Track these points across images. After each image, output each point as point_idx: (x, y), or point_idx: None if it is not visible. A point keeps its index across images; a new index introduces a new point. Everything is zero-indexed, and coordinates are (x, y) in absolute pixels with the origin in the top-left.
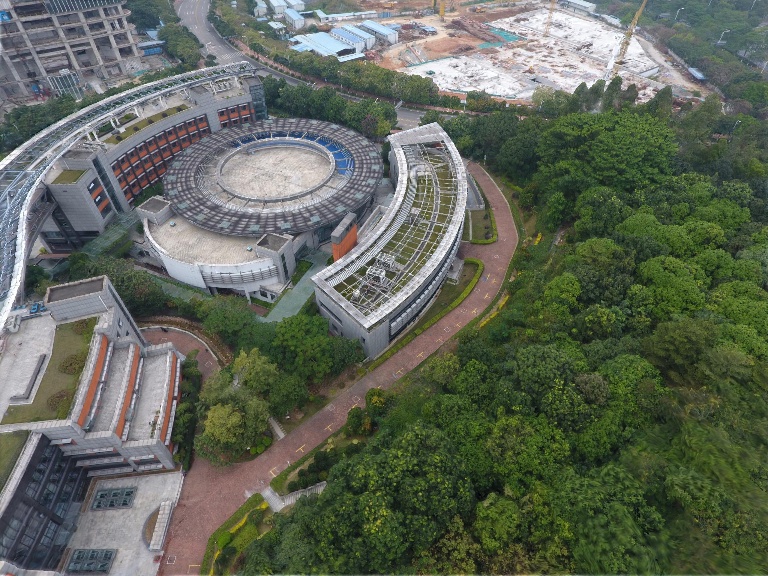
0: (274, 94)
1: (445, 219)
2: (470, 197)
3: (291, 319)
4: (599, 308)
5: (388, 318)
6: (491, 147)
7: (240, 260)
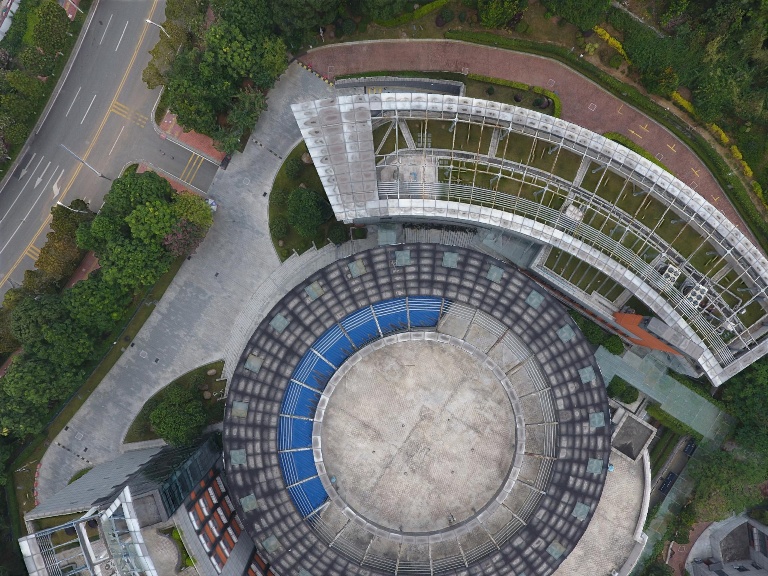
0: (1, 443)
1: (569, 167)
2: None
3: None
4: None
5: None
6: (315, 11)
7: (629, 479)
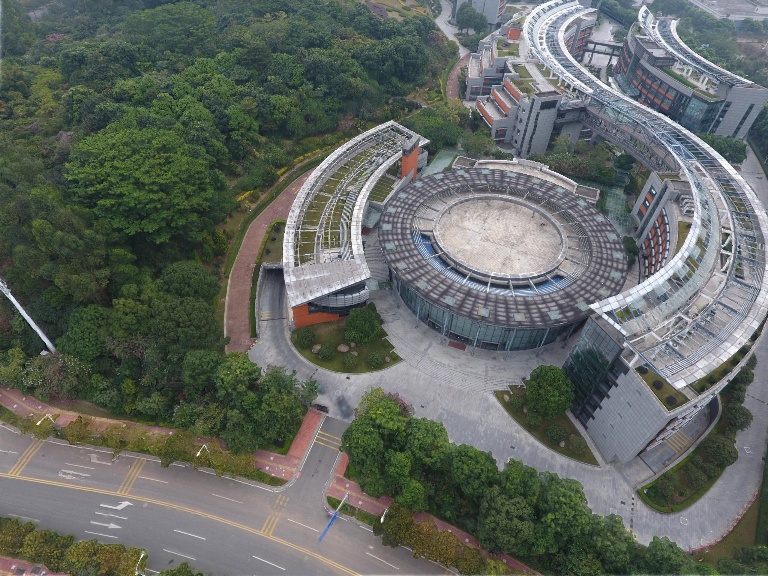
0: None
1: (322, 199)
2: (267, 298)
3: (435, 123)
4: (273, 80)
5: (379, 136)
6: None
7: None
